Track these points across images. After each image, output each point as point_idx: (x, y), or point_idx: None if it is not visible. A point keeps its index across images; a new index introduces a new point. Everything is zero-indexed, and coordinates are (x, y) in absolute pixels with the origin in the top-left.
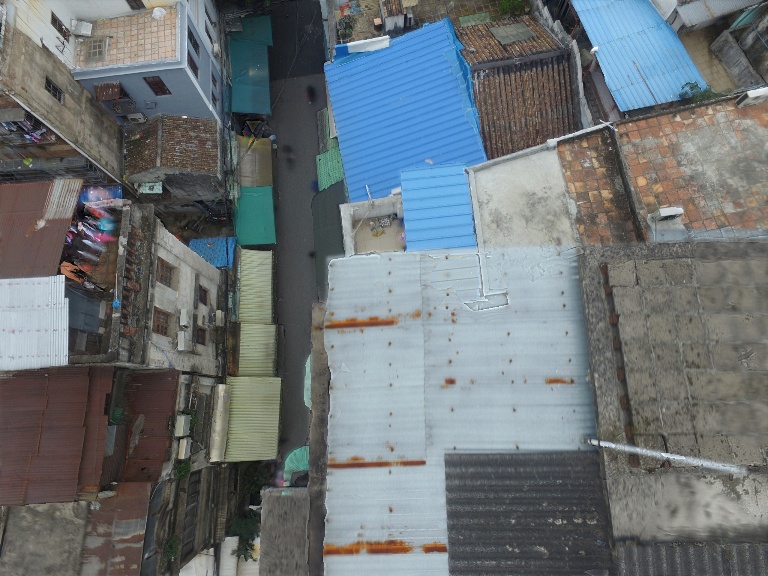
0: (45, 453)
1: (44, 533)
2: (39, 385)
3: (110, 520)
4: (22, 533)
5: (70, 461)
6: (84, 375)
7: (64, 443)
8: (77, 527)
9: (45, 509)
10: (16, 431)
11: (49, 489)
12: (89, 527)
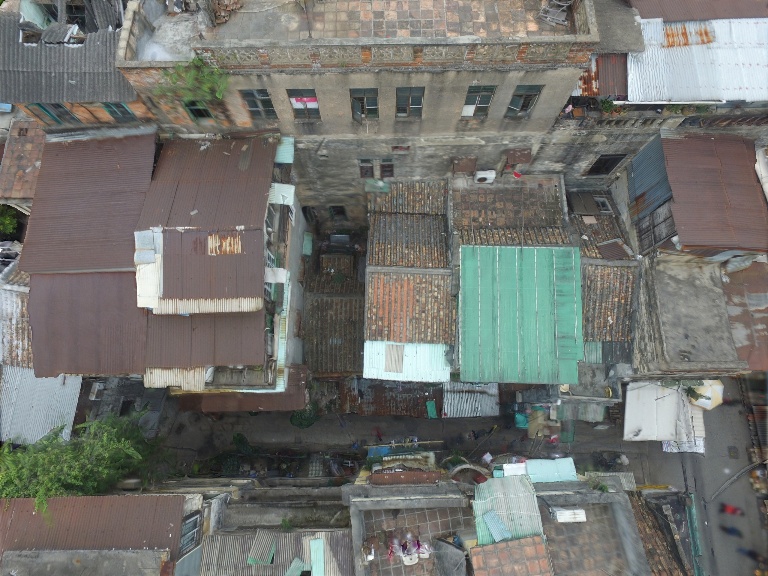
0: (735, 206)
1: (691, 299)
2: (708, 147)
3: (741, 293)
4: (671, 298)
5: (757, 215)
6: (741, 142)
7: (747, 199)
8: (718, 295)
9: (685, 278)
10: (705, 185)
11: (751, 236)
12: (725, 297)
